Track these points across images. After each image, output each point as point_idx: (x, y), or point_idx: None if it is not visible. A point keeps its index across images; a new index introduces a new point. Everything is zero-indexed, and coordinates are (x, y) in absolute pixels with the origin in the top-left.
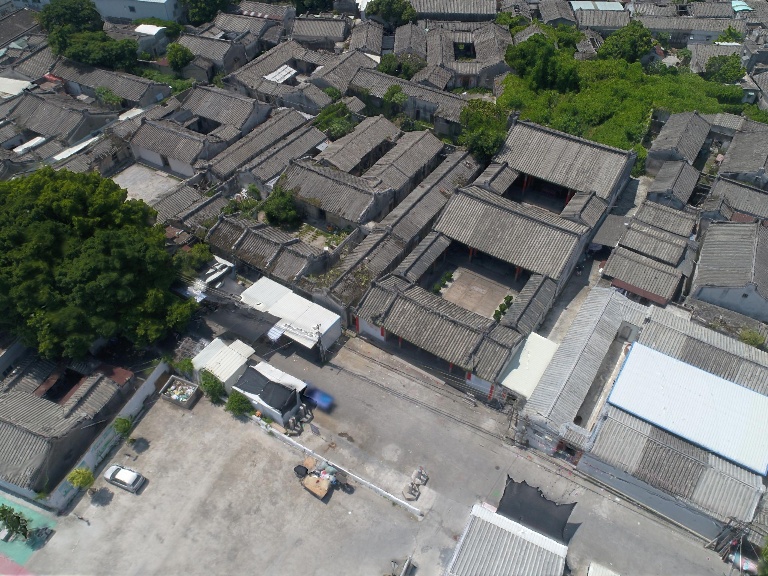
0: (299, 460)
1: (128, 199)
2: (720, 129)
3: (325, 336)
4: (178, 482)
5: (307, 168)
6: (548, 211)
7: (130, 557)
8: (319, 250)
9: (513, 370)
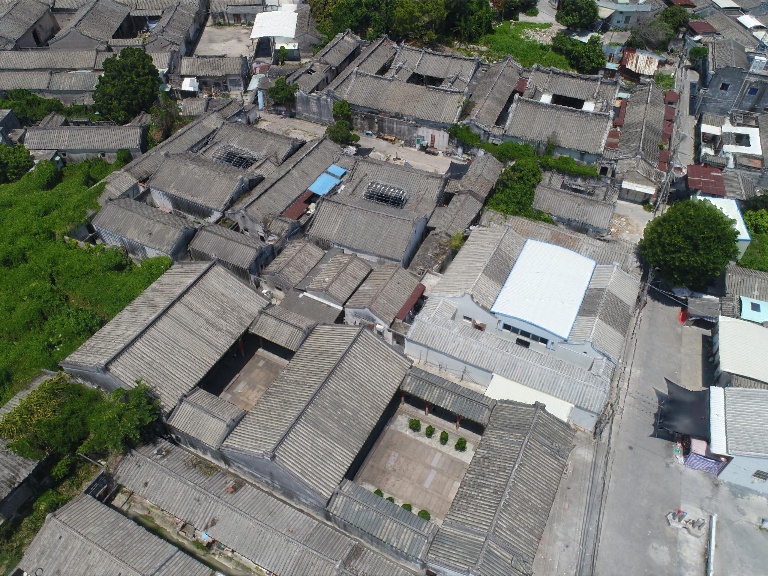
0: None
1: None
2: (123, 195)
3: None
4: None
5: None
6: (239, 375)
7: None
8: None
9: None
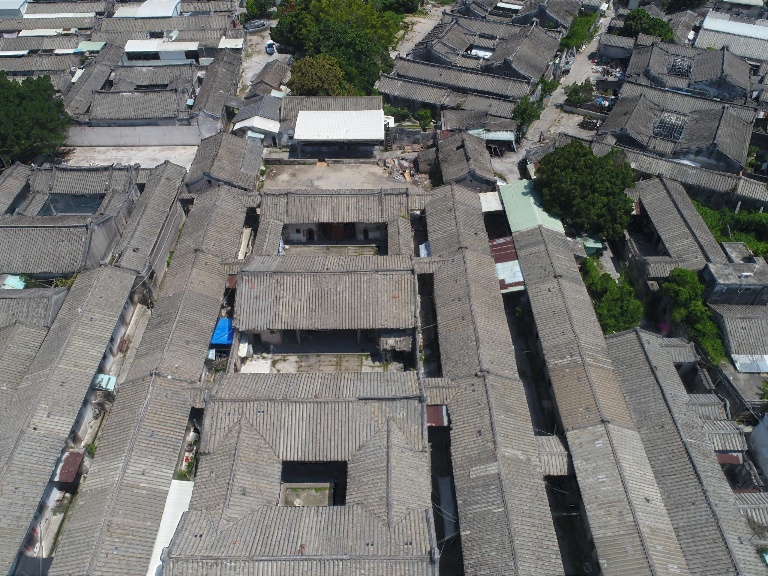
0: None
1: None
2: None
3: None
4: None
5: None
6: None
7: None
8: None
9: None
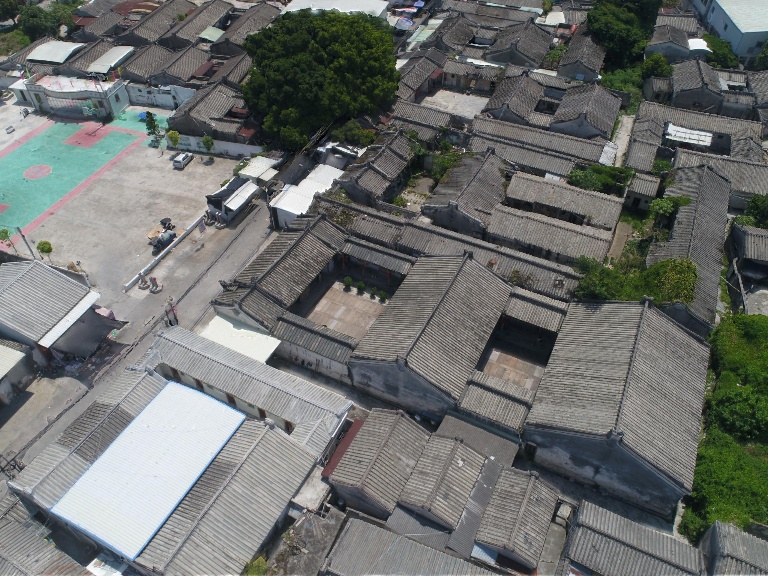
0: (185, 228)
1: (449, 107)
2: None
3: (283, 213)
4: (179, 181)
5: (483, 160)
6: None
7: (134, 175)
8: (378, 191)
9: (232, 324)
